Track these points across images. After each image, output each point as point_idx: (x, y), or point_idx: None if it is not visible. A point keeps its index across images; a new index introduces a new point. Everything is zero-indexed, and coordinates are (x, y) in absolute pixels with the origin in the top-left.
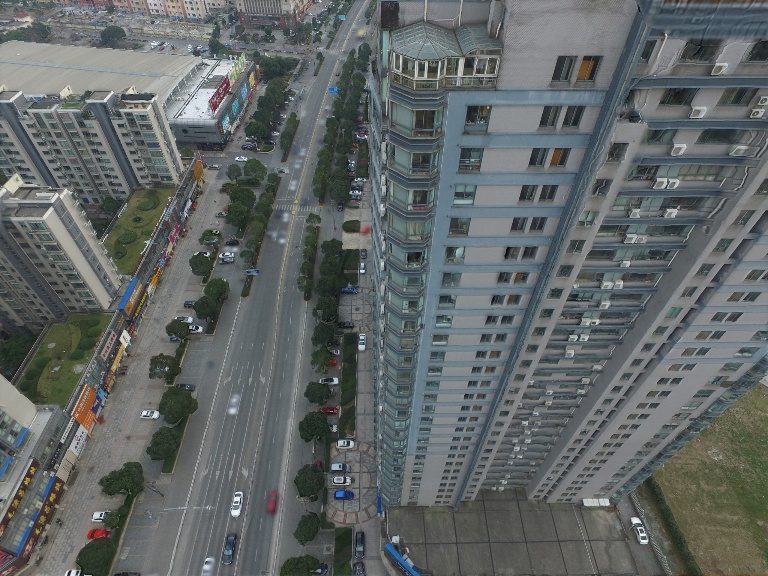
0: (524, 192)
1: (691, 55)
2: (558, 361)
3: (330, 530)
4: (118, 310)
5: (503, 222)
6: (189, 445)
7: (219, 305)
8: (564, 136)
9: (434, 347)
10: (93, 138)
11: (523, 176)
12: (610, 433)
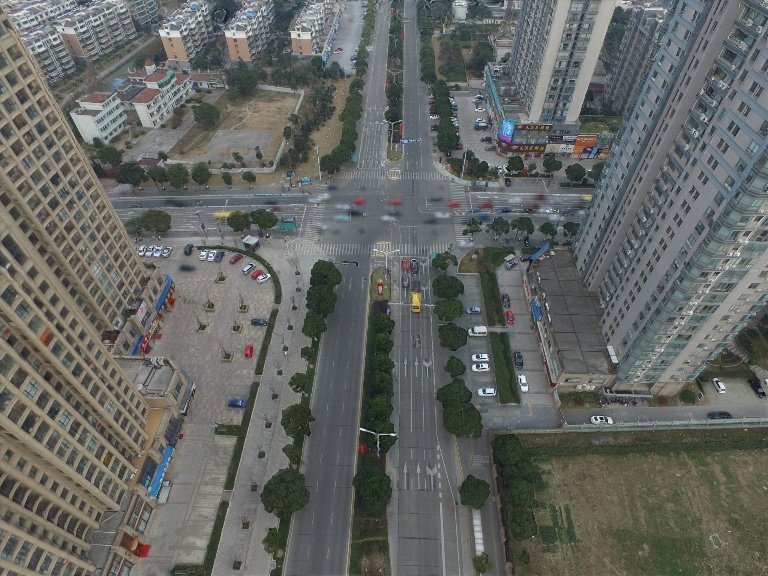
0: None
1: None
2: None
3: None
4: None
5: None
6: (579, 191)
7: None
8: None
9: None
10: None
11: None
12: None
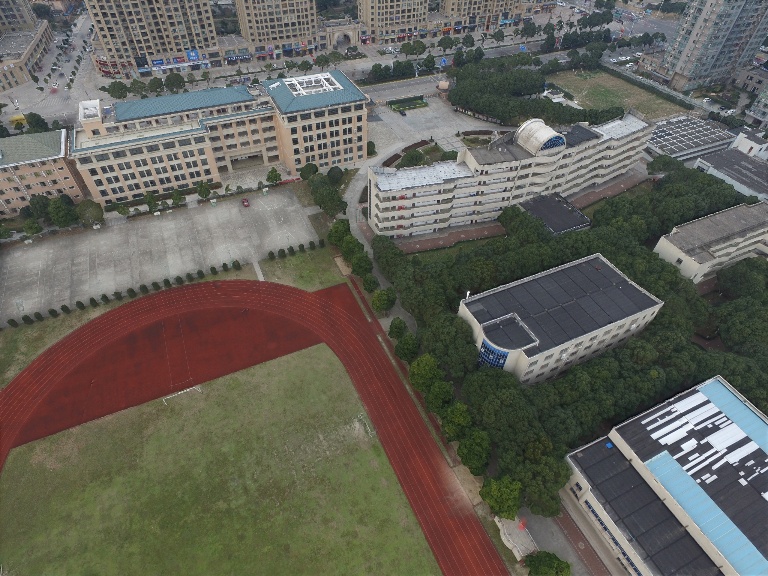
0: None
1: None
2: None
3: None
4: None
5: None
6: None
7: None
8: None
9: None
10: None
11: None
12: None
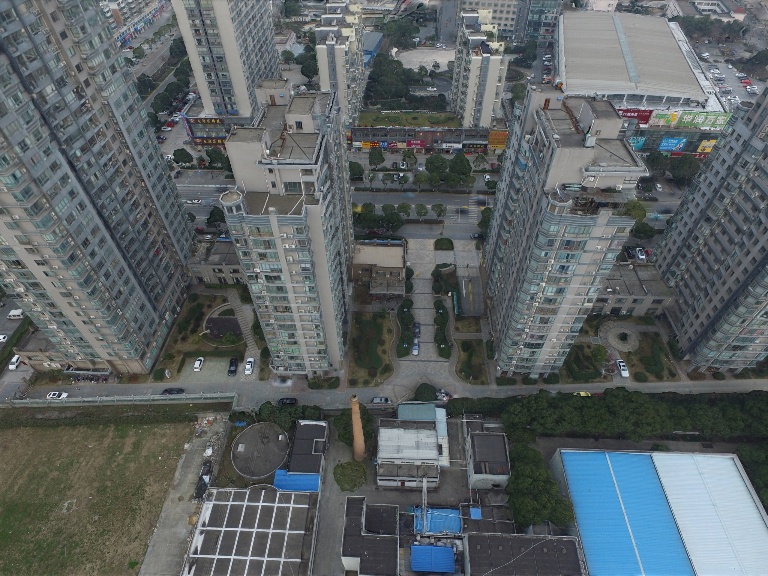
0: None
1: None
2: None
3: None
4: None
5: None
6: None
7: None
8: None
9: None
10: None
11: None
12: None
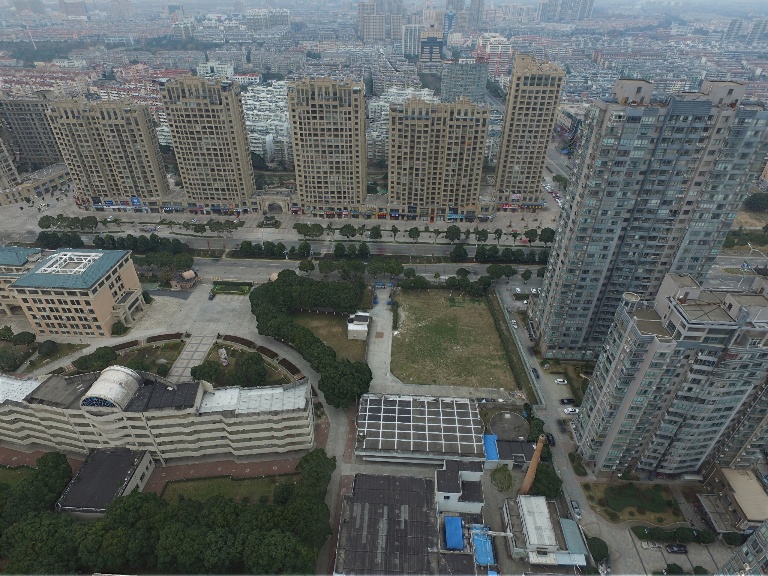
0: None
1: None
2: None
3: None
4: None
5: None
6: None
7: None
8: None
9: None
10: None
11: None
12: None
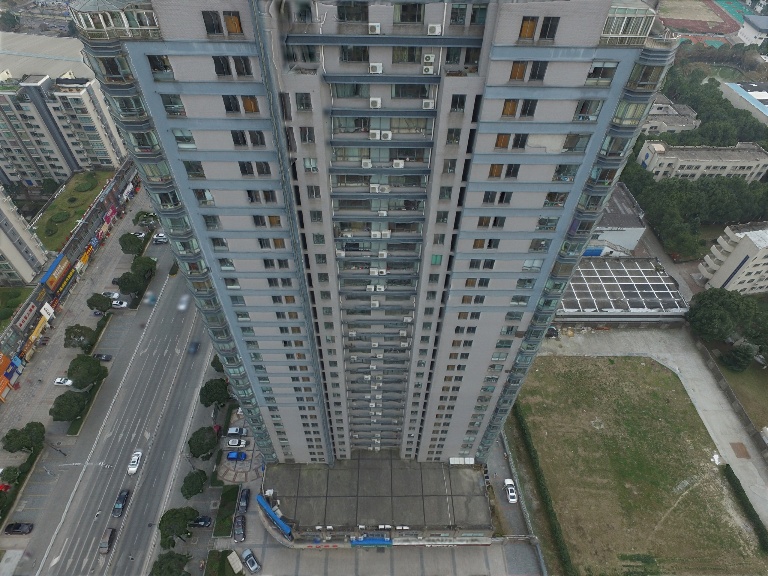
0: (235, 137)
1: (337, 14)
2: (370, 312)
3: (219, 487)
4: (40, 283)
5: (231, 166)
6: (98, 410)
7: (142, 281)
8: (243, 84)
9: (230, 291)
10: (30, 121)
11: (226, 121)
12: (439, 385)
